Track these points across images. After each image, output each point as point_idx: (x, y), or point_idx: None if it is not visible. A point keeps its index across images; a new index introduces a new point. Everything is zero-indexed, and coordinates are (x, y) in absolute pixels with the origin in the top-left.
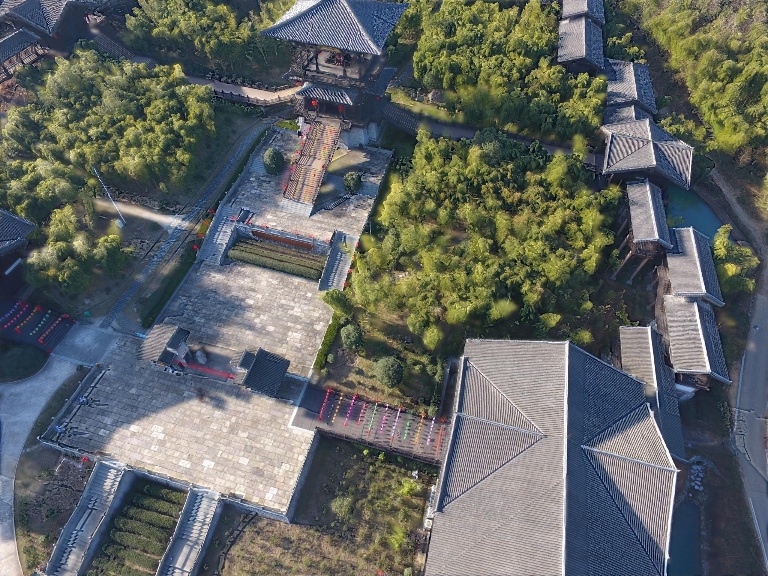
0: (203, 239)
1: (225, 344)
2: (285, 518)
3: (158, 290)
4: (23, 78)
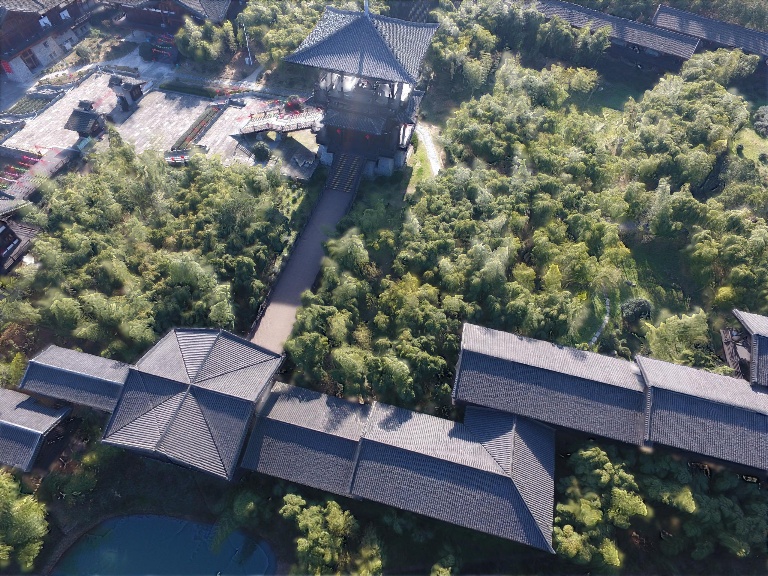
0: (225, 94)
1: (132, 117)
2: None
3: (184, 84)
4: None
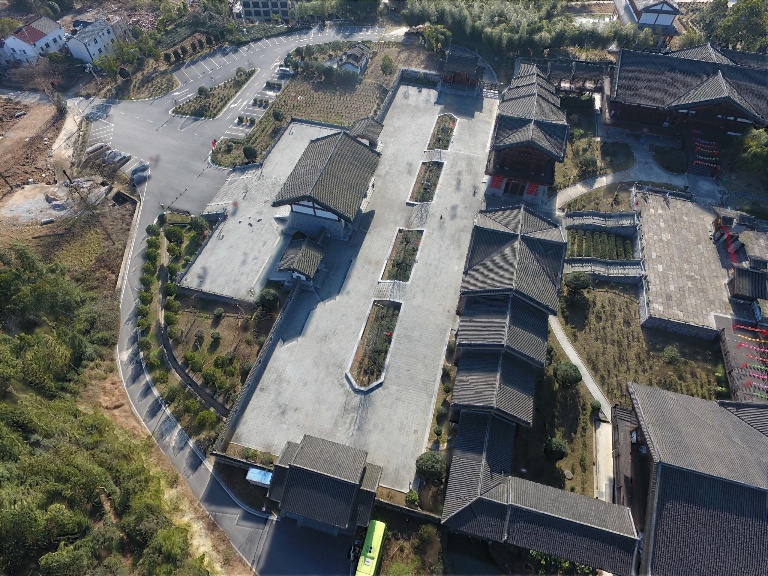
0: None
1: None
2: (645, 318)
3: None
4: None
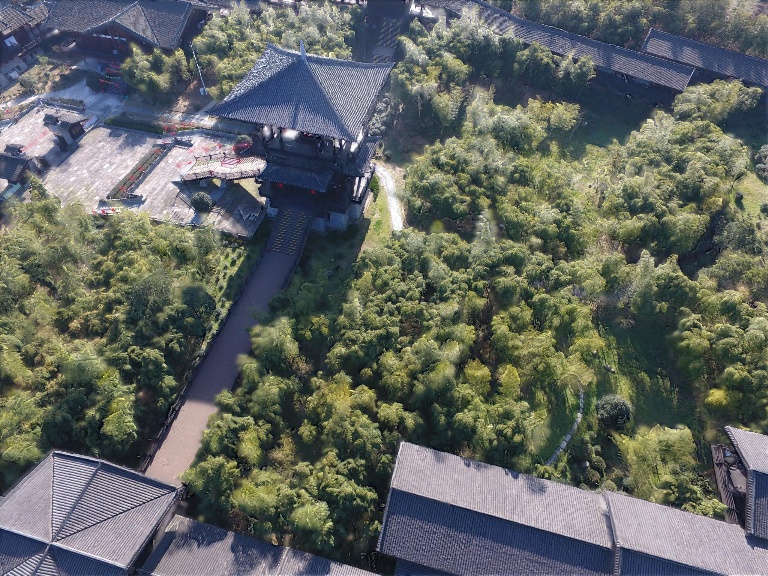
0: (173, 131)
1: (71, 158)
2: None
3: (131, 119)
4: (312, 1)
